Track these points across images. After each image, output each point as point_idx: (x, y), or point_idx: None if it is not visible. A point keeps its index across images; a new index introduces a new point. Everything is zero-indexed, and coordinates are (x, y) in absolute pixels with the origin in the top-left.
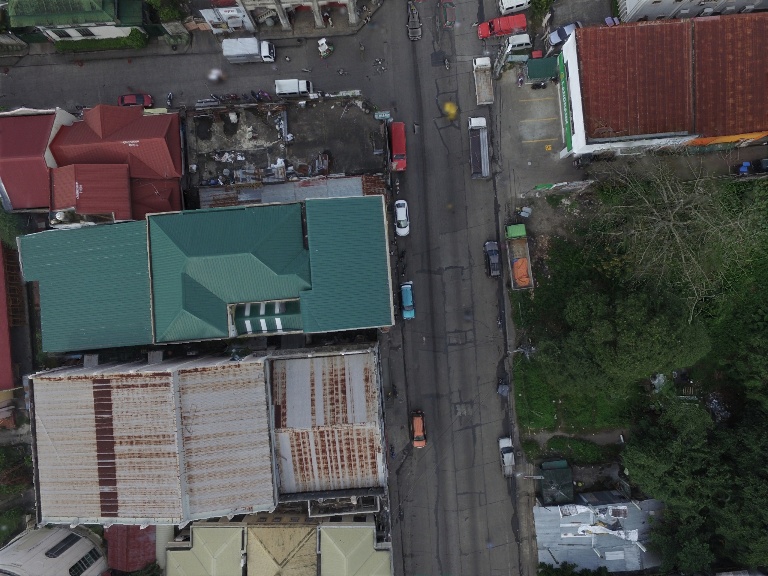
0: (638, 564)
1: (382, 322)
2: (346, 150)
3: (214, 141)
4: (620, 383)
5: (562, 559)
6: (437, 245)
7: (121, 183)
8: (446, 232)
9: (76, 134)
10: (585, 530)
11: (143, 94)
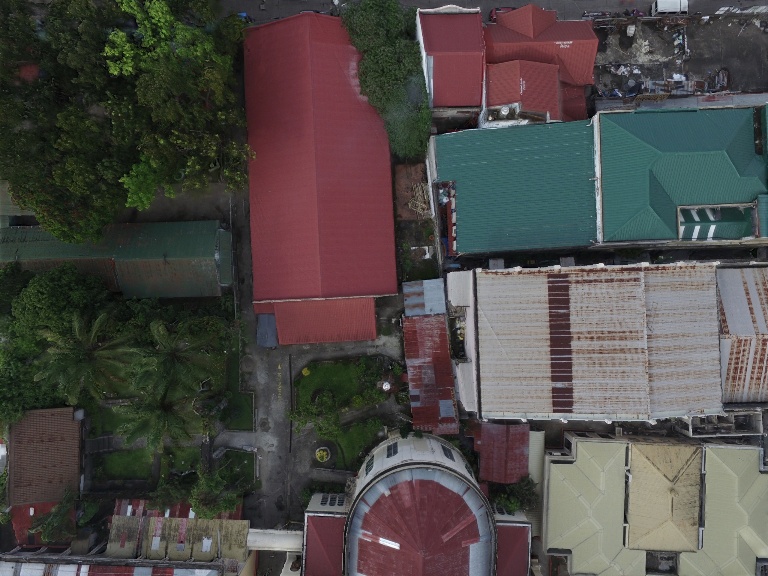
0: None
1: None
2: (743, 68)
3: (609, 54)
4: None
5: None
6: None
7: (553, 83)
8: None
9: (500, 34)
10: None
11: (516, 8)
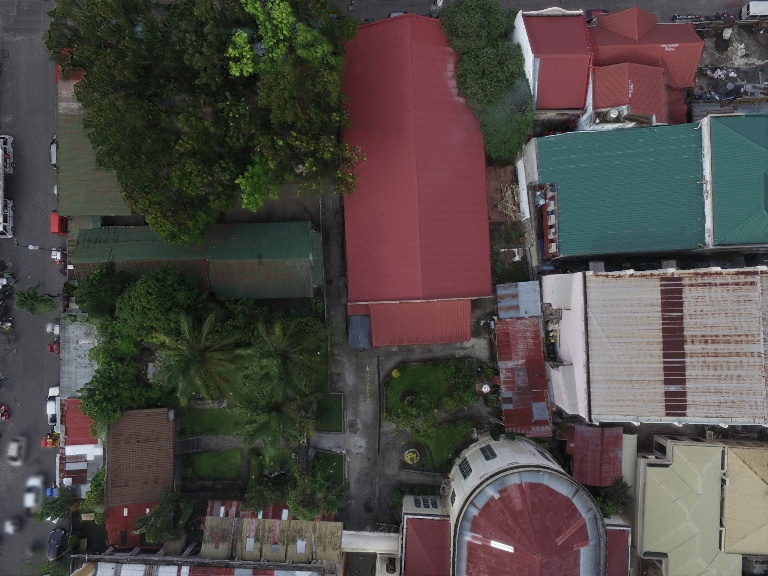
0: None
1: None
2: None
3: (705, 57)
4: None
5: None
6: None
7: (659, 86)
8: None
9: (603, 37)
10: None
11: None
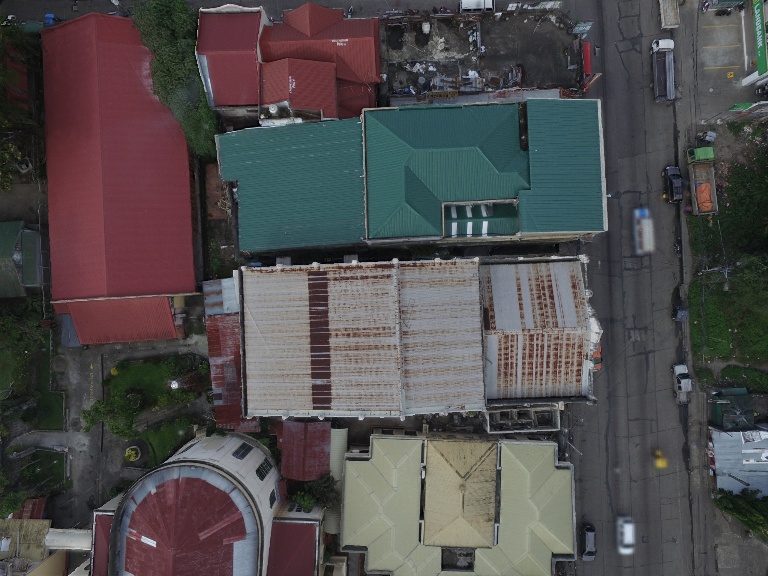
0: None
1: (595, 227)
2: (538, 65)
3: (405, 51)
4: None
5: (742, 486)
6: (615, 169)
7: (329, 81)
8: (625, 156)
9: (281, 33)
10: None
11: (324, 6)
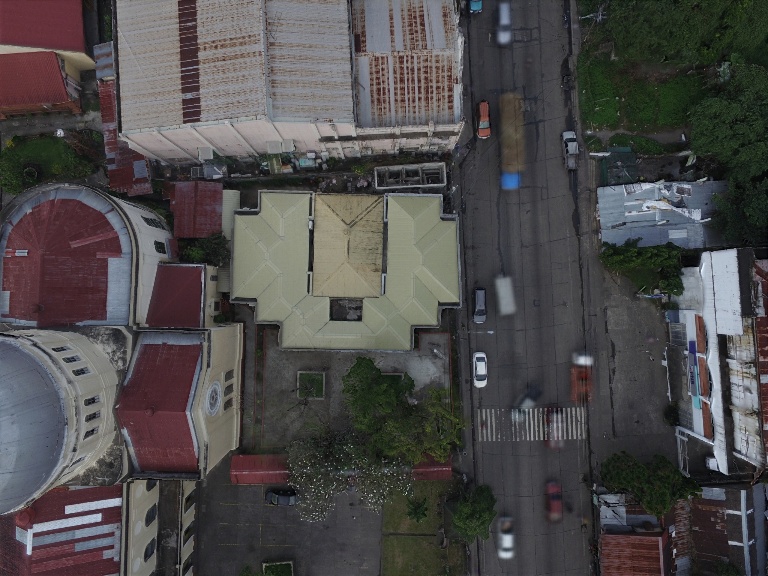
0: (701, 242)
1: None
2: None
3: None
4: (696, 23)
5: (625, 237)
6: None
7: None
8: None
9: None
10: (650, 206)
11: None
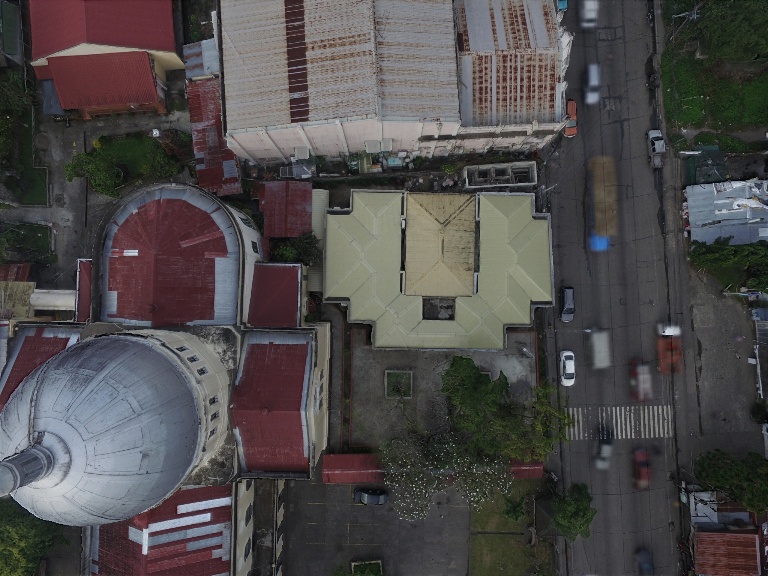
0: None
1: None
2: None
3: None
4: None
5: (715, 236)
6: None
7: None
8: None
9: None
10: (740, 204)
11: None
